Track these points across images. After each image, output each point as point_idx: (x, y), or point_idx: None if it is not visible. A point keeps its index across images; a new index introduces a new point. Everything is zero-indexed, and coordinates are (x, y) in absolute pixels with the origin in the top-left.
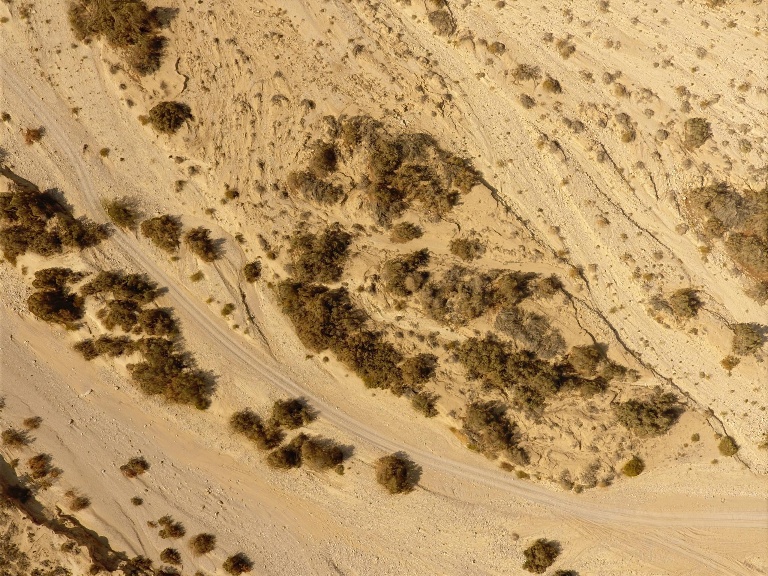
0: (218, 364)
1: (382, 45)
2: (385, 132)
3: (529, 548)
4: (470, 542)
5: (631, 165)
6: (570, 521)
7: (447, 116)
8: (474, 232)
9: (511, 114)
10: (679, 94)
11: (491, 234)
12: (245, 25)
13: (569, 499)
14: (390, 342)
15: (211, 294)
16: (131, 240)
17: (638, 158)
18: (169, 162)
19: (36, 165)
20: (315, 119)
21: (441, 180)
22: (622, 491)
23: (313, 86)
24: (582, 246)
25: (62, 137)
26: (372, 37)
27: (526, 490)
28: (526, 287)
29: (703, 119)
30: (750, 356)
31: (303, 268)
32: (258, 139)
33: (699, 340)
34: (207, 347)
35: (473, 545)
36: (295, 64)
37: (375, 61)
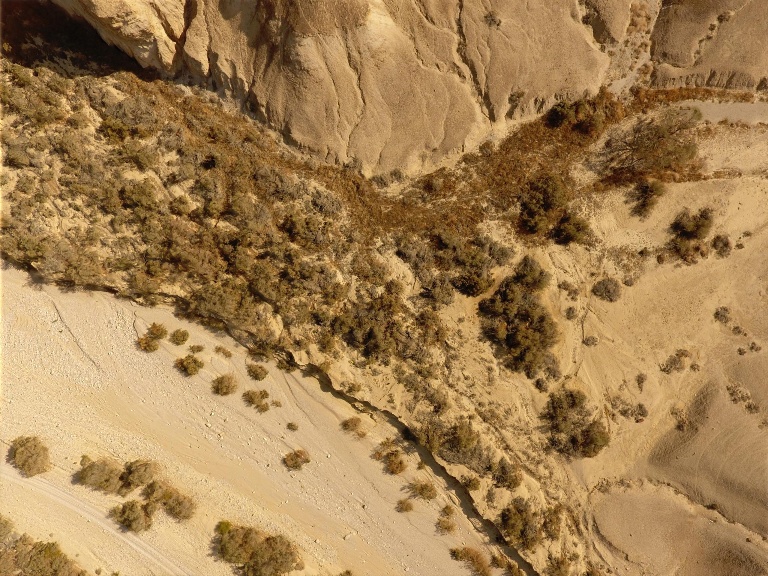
0: (209, 568)
1: None
2: None
3: None
4: None
5: None
6: None
7: None
8: None
9: None
10: None
11: None
12: None
13: None
14: None
15: None
16: None
17: None
18: None
19: None
20: None
21: None
22: None
23: None
24: None
25: None
26: None
27: None
28: None
29: None
30: None
31: None
32: None
33: None
34: None
35: None
36: None
37: None
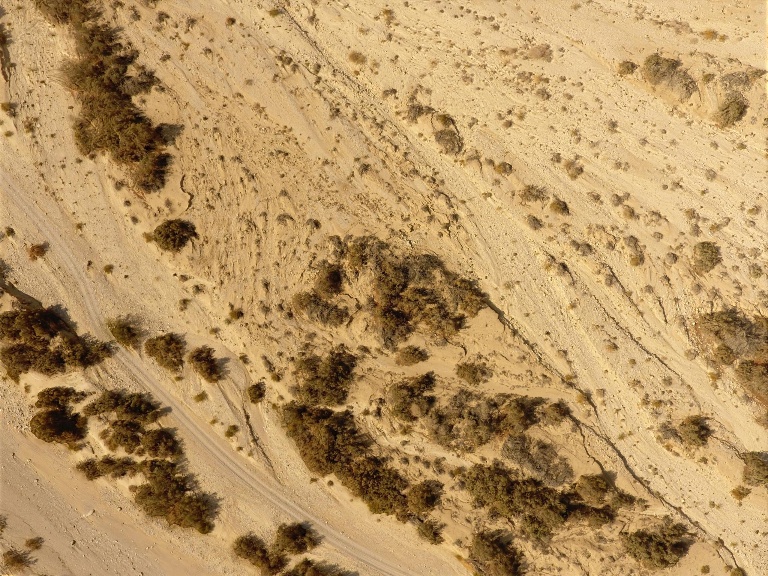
0: (221, 486)
1: (388, 164)
2: (391, 254)
3: None
4: None
5: (640, 289)
6: None
7: (453, 237)
8: (481, 356)
9: (518, 235)
10: (688, 217)
11: (498, 358)
12: (250, 143)
13: None
14: (395, 468)
15: (215, 415)
16: (135, 358)
17: (647, 282)
18: (173, 280)
19: (40, 281)
20: (320, 239)
21: (447, 303)
22: None
23: (318, 205)
24: (590, 370)
25: (66, 253)
26: (378, 156)
27: None
28: (533, 413)
29: (713, 244)
30: (761, 487)
31: (308, 394)
32: (263, 258)
33: (709, 469)
34: (210, 469)
35: None
36: (300, 183)
37: (381, 181)
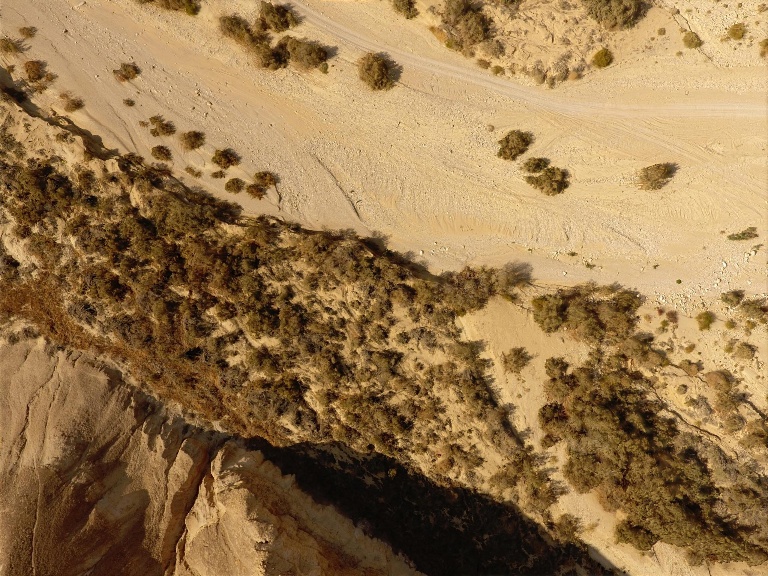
0: None
1: None
2: None
3: (503, 137)
4: (448, 134)
5: None
6: (542, 114)
7: None
8: None
9: None
10: None
11: None
12: None
13: (542, 94)
14: None
15: None
16: None
17: None
18: None
19: None
20: None
21: None
22: (592, 86)
23: None
24: None
25: None
26: None
27: (501, 86)
28: None
29: None
30: None
31: None
32: None
33: None
34: None
35: (450, 136)
36: None
37: None
